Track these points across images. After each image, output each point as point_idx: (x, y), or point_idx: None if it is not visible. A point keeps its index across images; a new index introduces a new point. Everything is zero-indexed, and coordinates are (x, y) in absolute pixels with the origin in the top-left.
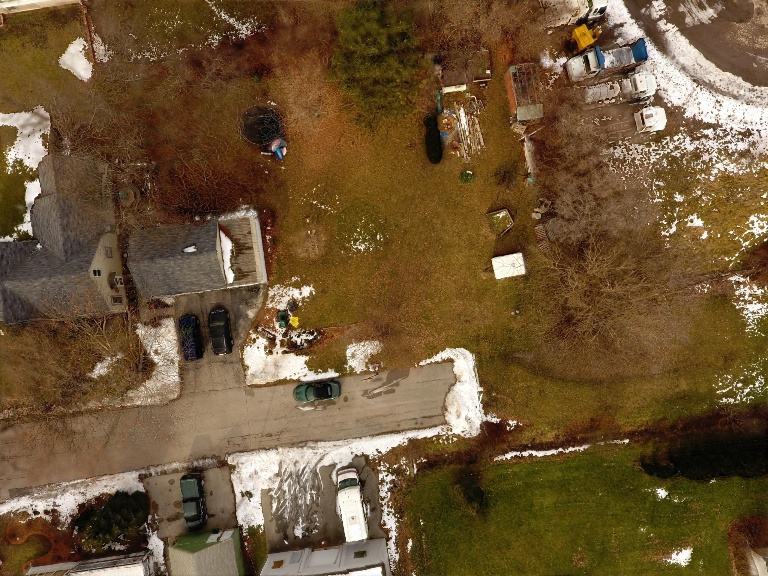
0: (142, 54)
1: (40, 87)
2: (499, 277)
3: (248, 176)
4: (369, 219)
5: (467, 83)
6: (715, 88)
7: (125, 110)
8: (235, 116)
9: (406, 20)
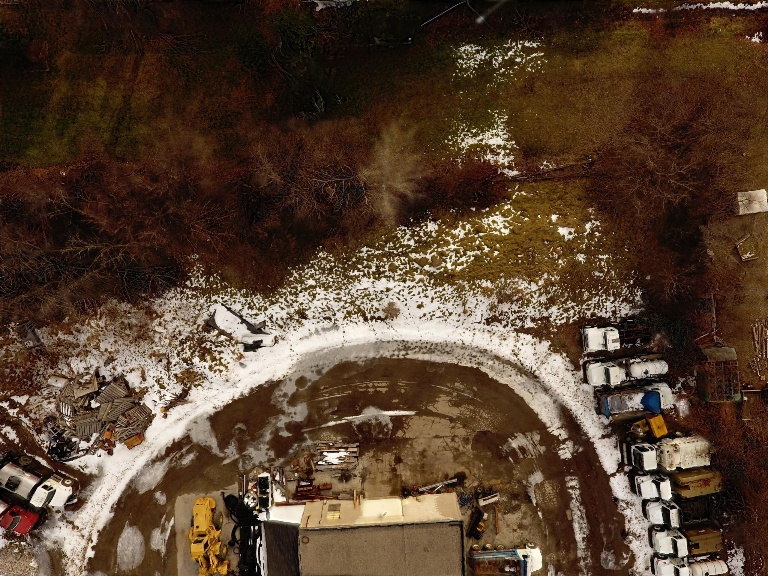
0: None
1: None
2: (764, 191)
3: None
4: None
5: (761, 390)
6: (517, 368)
7: None
8: None
9: None
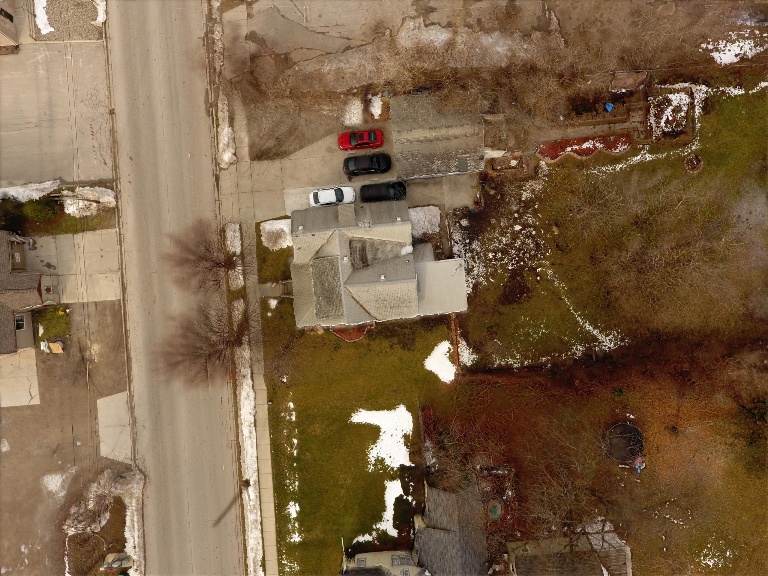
0: (506, 360)
1: (404, 387)
2: None
3: (605, 488)
4: (720, 536)
5: None
6: None
7: (486, 415)
8: (595, 428)
9: (766, 340)
